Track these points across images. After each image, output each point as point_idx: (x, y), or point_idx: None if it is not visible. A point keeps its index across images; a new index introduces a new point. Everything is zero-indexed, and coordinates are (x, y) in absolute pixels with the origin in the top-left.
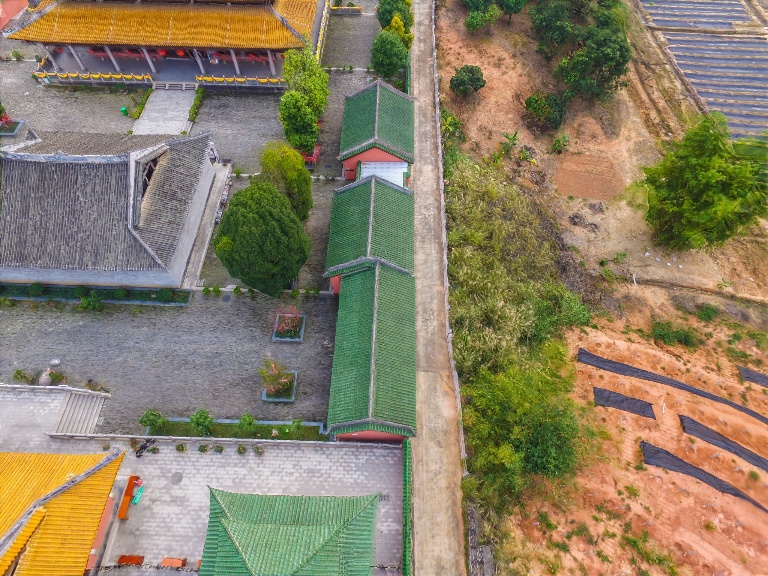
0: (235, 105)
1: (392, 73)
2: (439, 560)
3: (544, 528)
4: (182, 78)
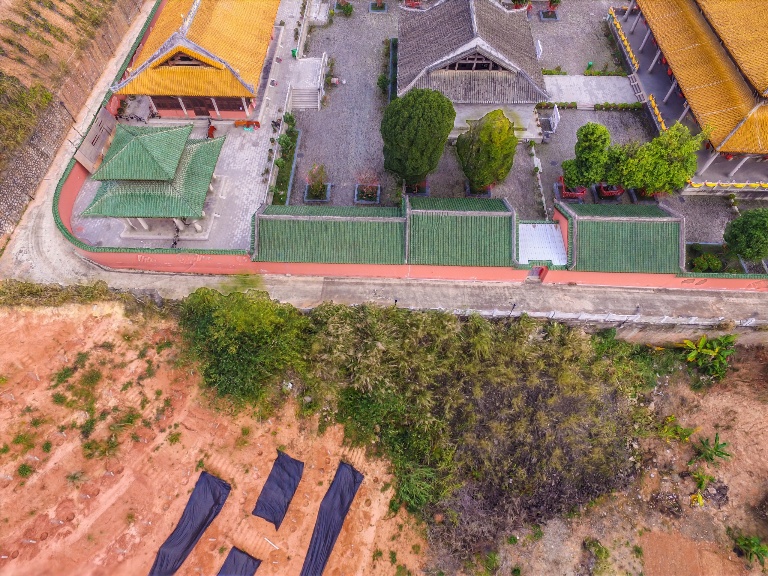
0: (632, 134)
1: (762, 272)
2: (173, 291)
3: (161, 344)
4: (650, 90)
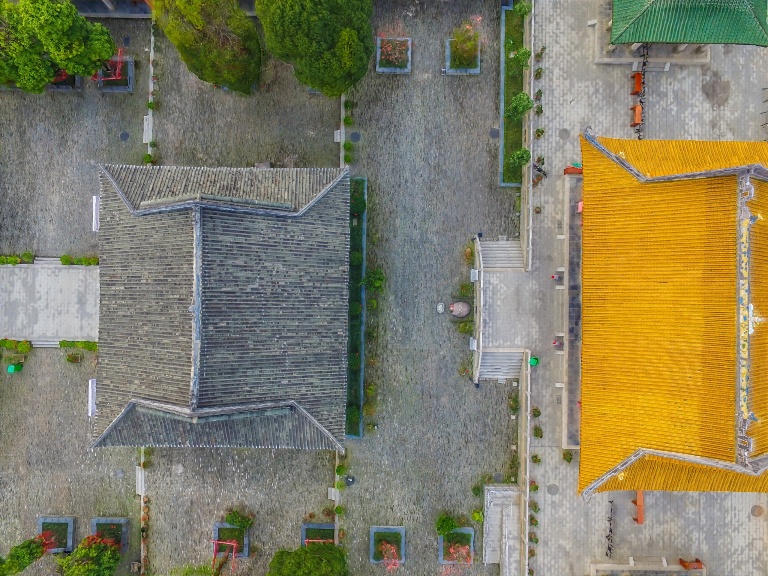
0: None
1: None
2: None
3: None
4: None
